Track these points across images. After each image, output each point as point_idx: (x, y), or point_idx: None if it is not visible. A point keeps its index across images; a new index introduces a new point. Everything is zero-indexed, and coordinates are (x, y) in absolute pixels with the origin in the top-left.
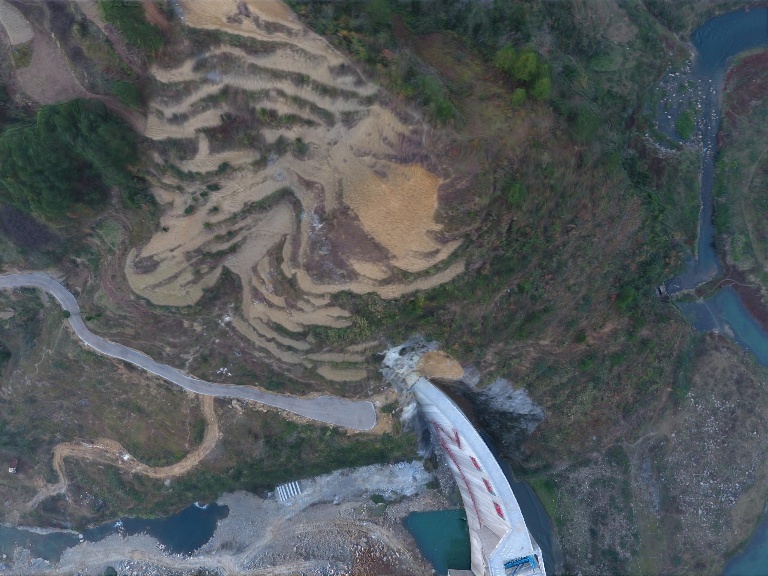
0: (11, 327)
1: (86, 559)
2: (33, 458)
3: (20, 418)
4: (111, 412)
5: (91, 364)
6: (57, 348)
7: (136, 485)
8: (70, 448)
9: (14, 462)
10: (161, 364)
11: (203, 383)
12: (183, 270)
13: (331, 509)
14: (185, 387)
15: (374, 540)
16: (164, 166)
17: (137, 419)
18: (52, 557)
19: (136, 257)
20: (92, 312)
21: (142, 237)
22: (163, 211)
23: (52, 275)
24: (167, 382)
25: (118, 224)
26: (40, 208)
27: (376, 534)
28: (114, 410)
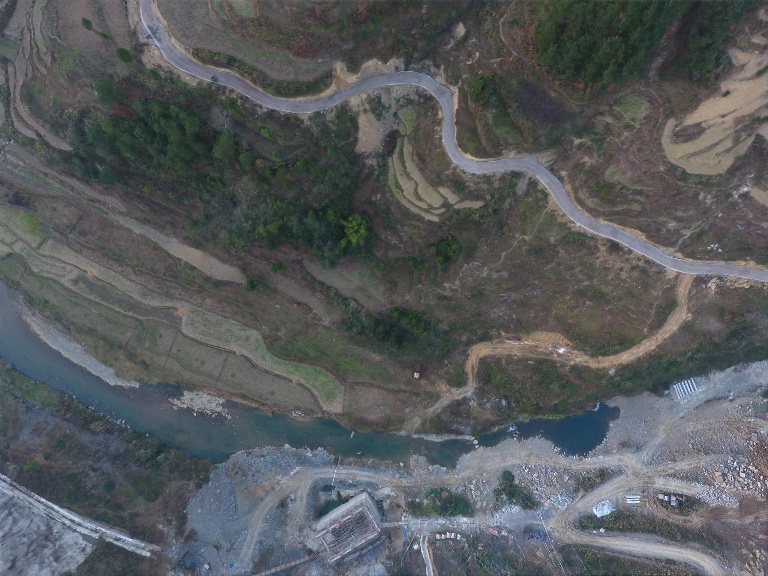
0: (479, 217)
1: (483, 464)
2: (441, 362)
3: (457, 315)
4: (561, 302)
5: (569, 248)
6: (537, 233)
7: (572, 378)
8: (491, 347)
9: (417, 368)
10: (646, 244)
11: (685, 262)
12: (726, 137)
13: (720, 407)
14: (668, 266)
15: (763, 435)
16: (767, 22)
17: (592, 307)
18: (448, 464)
19: (676, 126)
20: (606, 188)
21: (687, 106)
22: (728, 75)
23: (540, 159)
24: (649, 262)
25: (641, 99)
26: (613, 73)
27: (765, 429)
28: (567, 300)
